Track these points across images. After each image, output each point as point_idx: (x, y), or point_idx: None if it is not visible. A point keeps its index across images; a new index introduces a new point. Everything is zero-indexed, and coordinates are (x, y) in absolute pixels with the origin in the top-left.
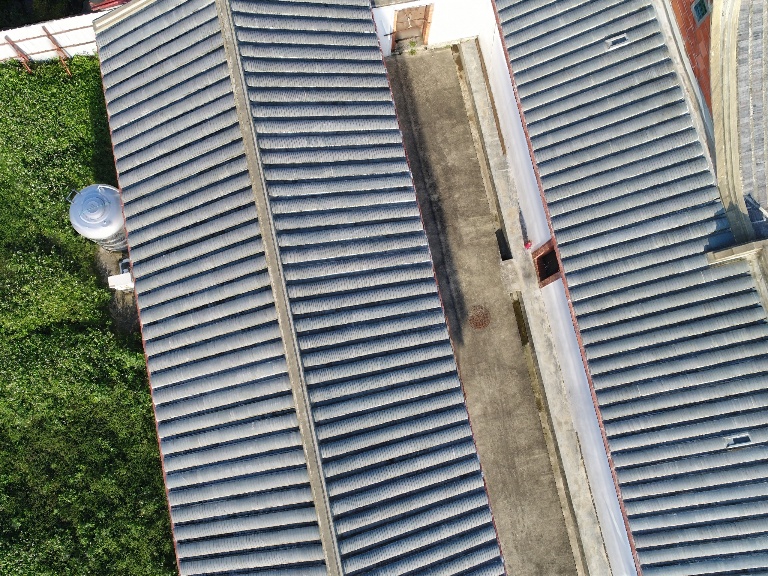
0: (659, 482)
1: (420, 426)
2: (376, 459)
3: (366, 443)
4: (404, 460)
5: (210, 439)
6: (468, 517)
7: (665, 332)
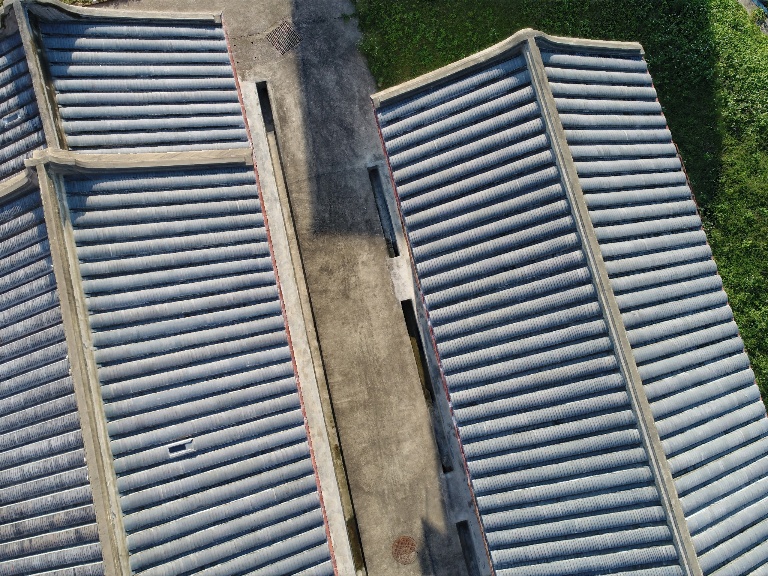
0: (261, 397)
1: (525, 457)
2: (575, 426)
3: (588, 442)
4: (543, 423)
5: (734, 438)
6: (469, 365)
7: (244, 567)
